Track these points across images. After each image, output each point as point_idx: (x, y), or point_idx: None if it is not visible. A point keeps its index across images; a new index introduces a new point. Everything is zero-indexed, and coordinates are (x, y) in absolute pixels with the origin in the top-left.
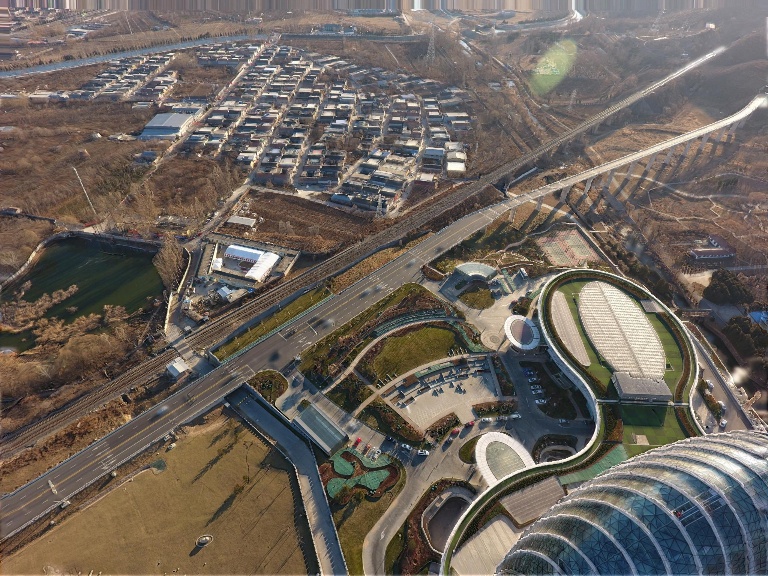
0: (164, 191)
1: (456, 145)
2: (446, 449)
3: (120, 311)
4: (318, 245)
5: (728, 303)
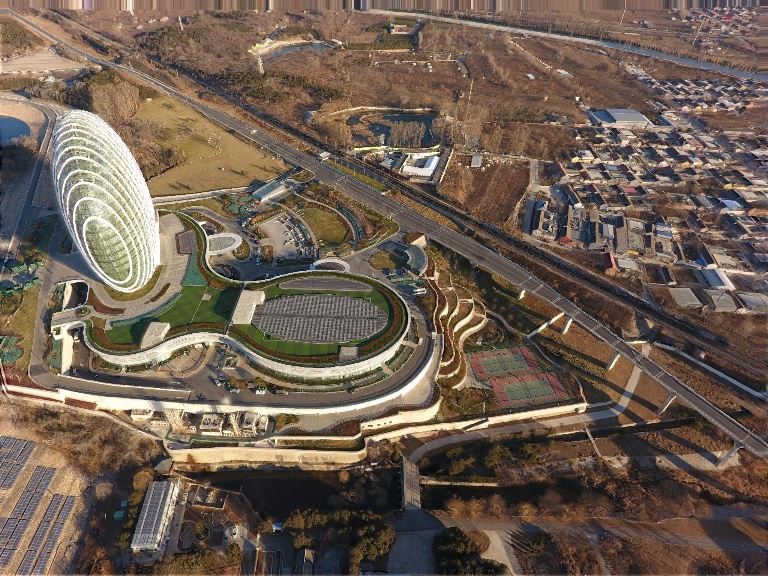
0: (507, 131)
1: (763, 304)
2: (244, 233)
3: (377, 140)
4: (444, 187)
5: (435, 557)
